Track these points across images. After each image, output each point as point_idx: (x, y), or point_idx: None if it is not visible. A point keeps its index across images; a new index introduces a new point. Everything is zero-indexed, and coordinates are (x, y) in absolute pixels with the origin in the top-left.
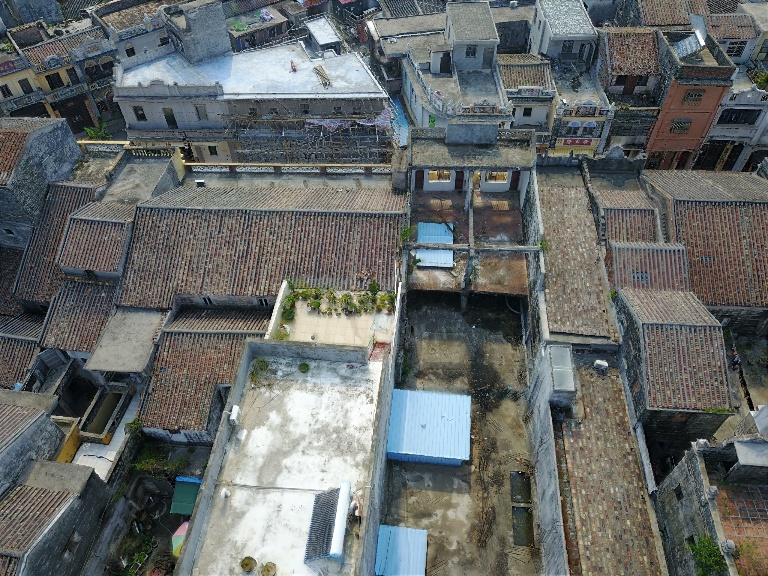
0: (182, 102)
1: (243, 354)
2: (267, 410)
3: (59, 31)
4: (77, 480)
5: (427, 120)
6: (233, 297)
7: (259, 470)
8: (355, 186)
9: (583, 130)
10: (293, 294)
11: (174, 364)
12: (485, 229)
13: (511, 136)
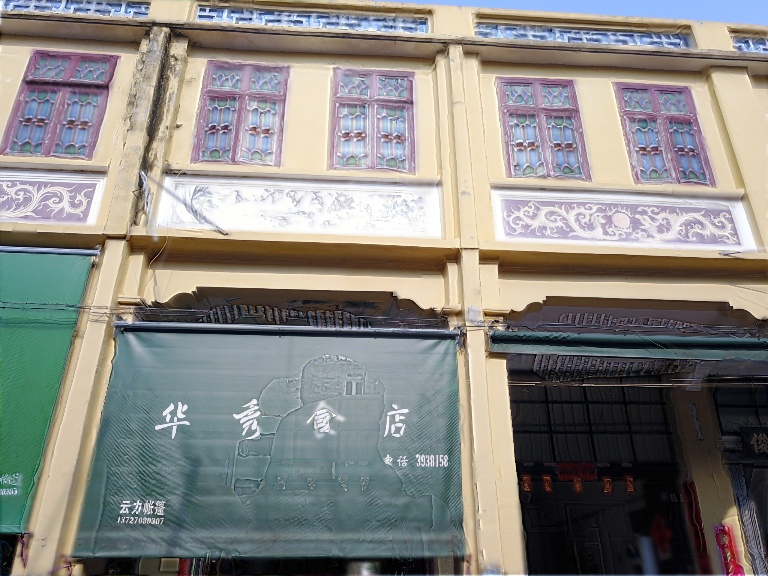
0: None
1: None
2: None
3: None
4: None
5: None
6: None
7: None
8: None
9: None
10: None
11: None
12: None
13: None
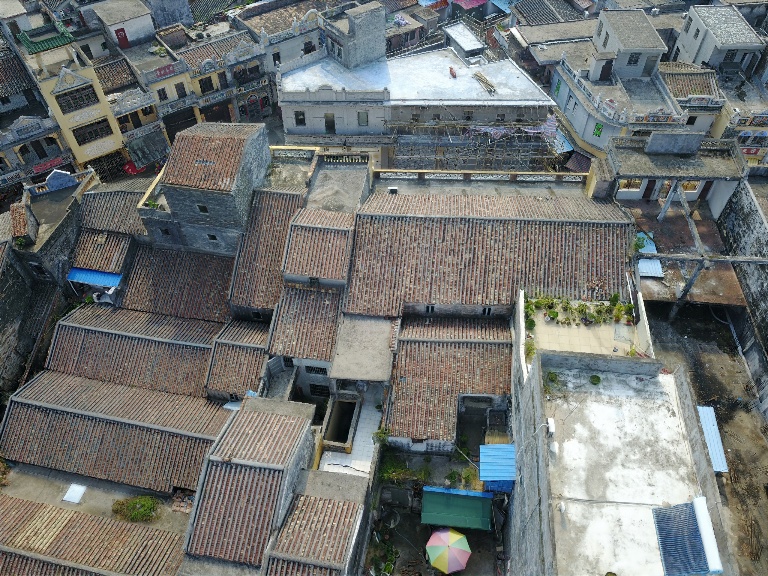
0: (346, 107)
1: (540, 366)
2: (571, 422)
3: (200, 34)
4: (356, 490)
5: (592, 128)
6: (459, 306)
7: (585, 483)
8: (549, 194)
9: (752, 139)
10: (527, 303)
11: (413, 373)
12: (684, 239)
13: (711, 146)
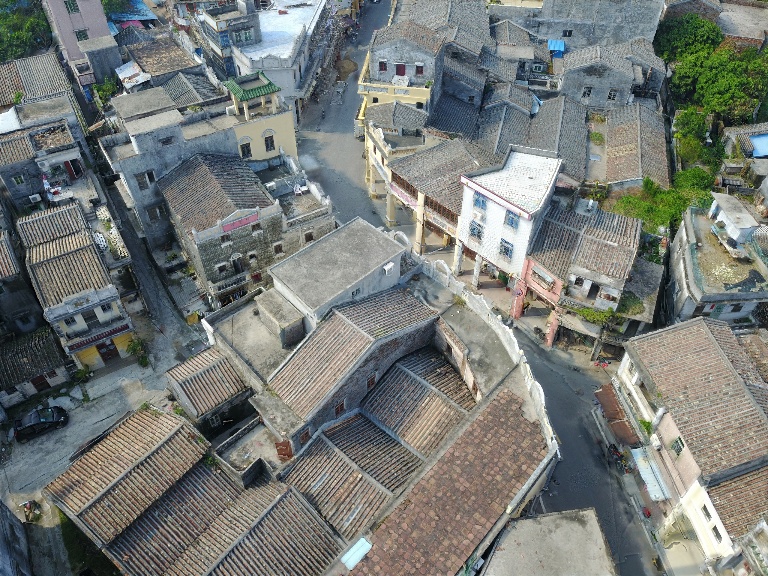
0: None
1: None
2: None
3: None
4: None
5: None
6: None
7: None
8: (407, 5)
9: None
10: None
11: None
12: None
13: None
